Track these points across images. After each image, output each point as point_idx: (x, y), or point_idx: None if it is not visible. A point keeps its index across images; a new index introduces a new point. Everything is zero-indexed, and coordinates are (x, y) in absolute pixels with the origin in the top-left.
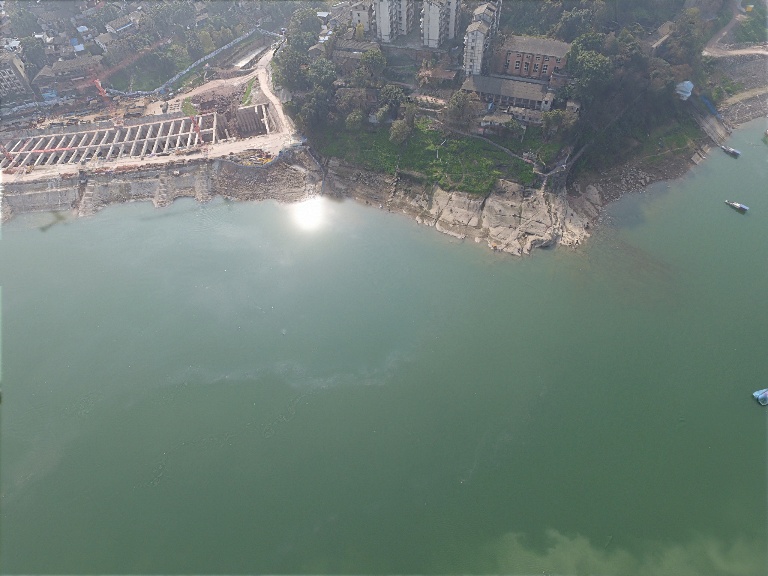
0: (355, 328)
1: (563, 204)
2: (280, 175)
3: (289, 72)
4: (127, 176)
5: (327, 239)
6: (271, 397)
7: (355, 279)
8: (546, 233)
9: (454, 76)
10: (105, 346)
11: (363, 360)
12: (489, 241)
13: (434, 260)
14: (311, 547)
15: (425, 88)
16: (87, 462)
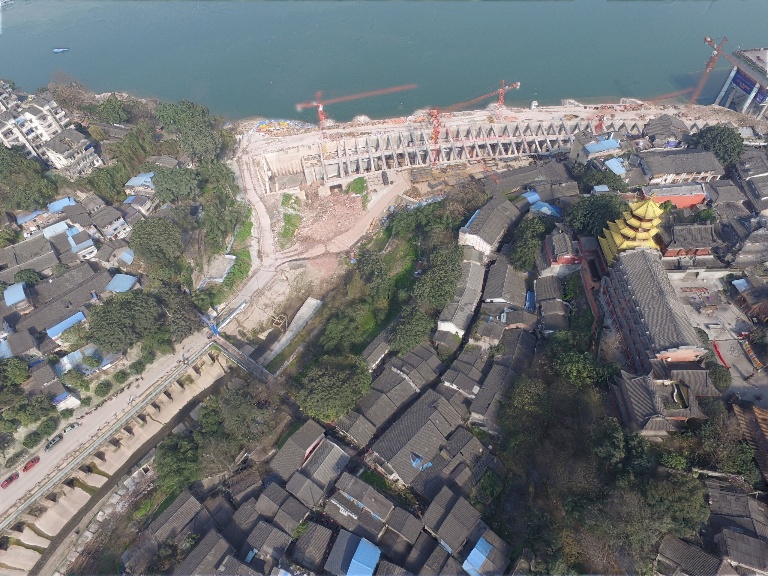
0: (228, 63)
1: None
2: None
3: None
4: None
5: (232, 99)
6: (274, 46)
7: (220, 80)
8: None
9: None
10: None
11: None
12: None
13: (168, 90)
14: (261, 21)
15: None
16: None
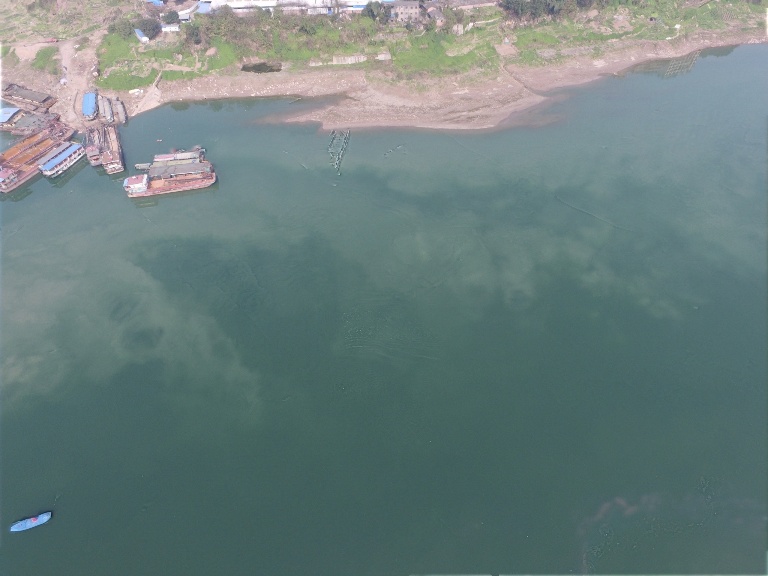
0: None
1: None
2: None
3: None
4: None
5: None
6: None
7: None
8: None
9: None
10: None
11: None
12: None
13: None
14: (529, 418)
15: None
16: None
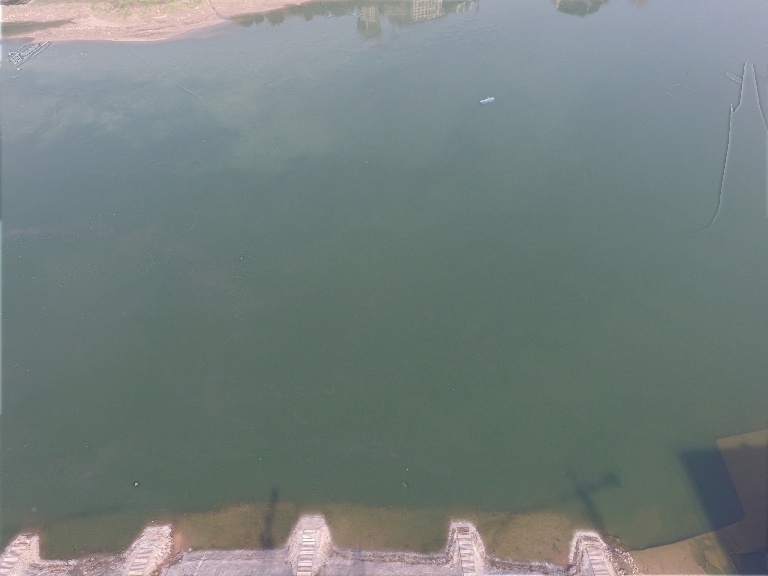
0: None
1: None
2: None
3: None
4: None
5: None
6: (6, 261)
7: None
8: None
9: None
10: (134, 309)
11: None
12: None
13: None
14: (25, 192)
15: None
16: (151, 233)
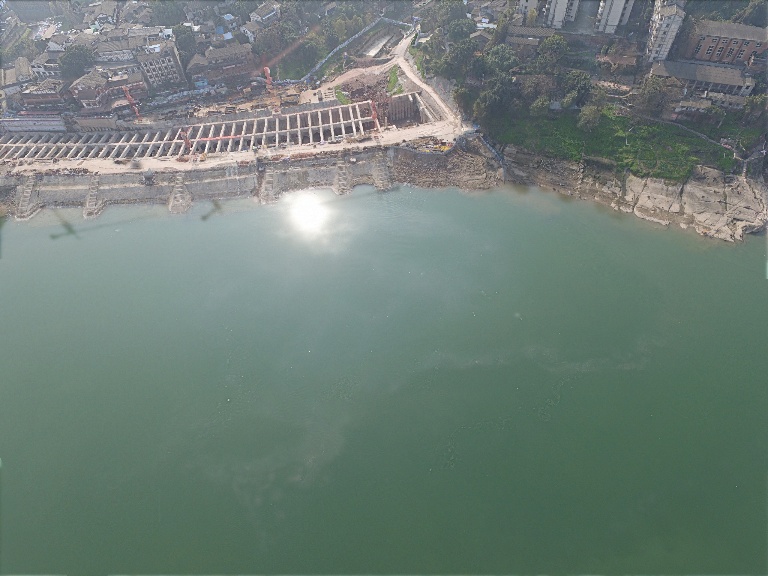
0: (592, 313)
1: (764, 190)
2: (460, 162)
3: (461, 59)
4: (304, 164)
5: (526, 226)
6: (531, 381)
7: (572, 265)
8: (757, 219)
9: (635, 62)
10: (340, 331)
11: (613, 345)
12: (696, 227)
13: (646, 246)
14: (633, 529)
15: (603, 74)
16: (366, 445)
